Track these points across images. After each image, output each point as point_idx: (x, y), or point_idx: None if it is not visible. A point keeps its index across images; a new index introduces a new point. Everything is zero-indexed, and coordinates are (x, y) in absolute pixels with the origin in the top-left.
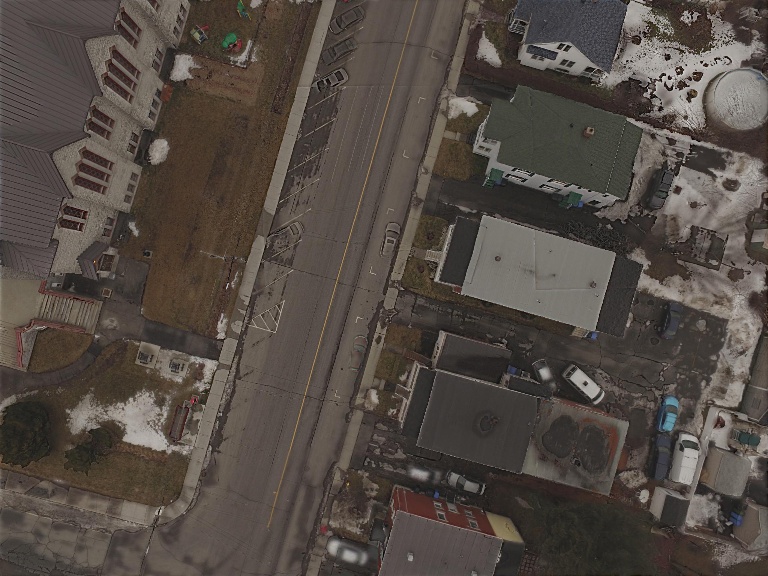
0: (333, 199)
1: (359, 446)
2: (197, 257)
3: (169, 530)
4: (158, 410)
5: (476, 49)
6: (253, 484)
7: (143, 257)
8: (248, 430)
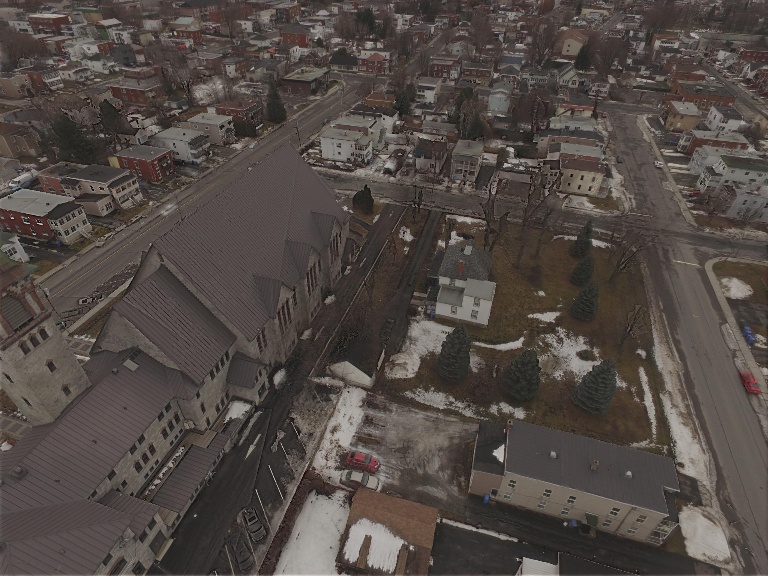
0: None
1: None
2: None
3: None
4: None
5: None
6: None
7: None
8: None
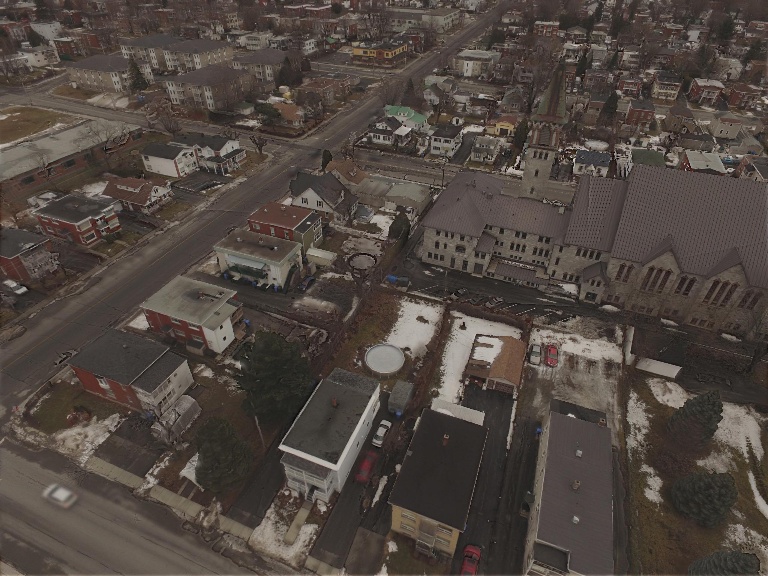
0: None
1: None
2: None
3: None
4: None
5: None
6: None
7: None
8: None
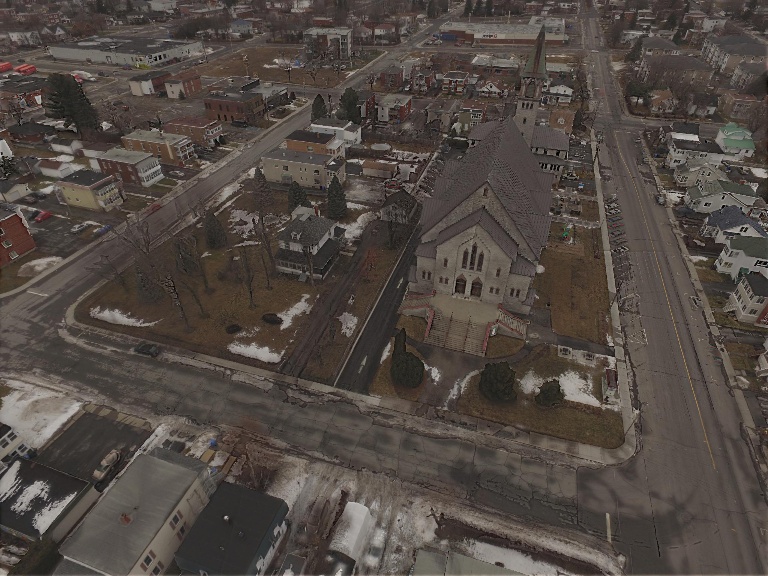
0: (648, 288)
1: (754, 411)
2: (579, 308)
3: (626, 468)
4: (584, 382)
5: (693, 238)
6: (683, 434)
7: (545, 307)
8: (658, 398)
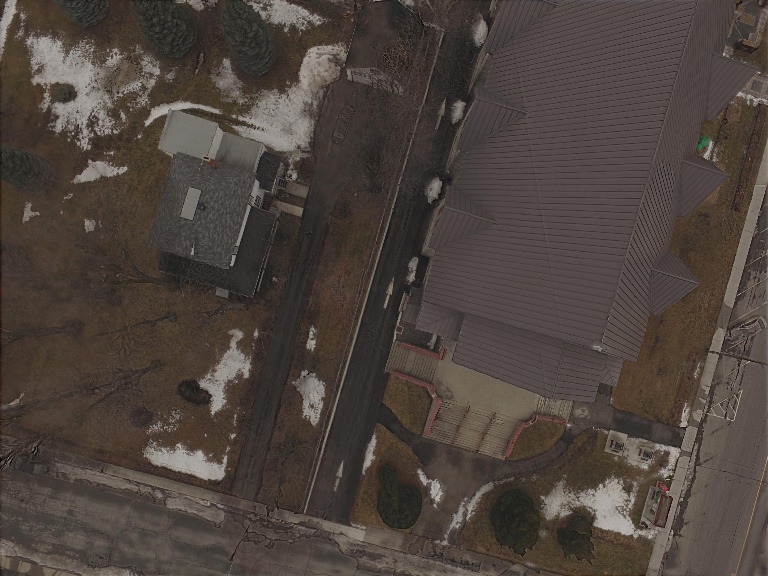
0: None
1: None
2: (663, 349)
3: None
4: (626, 496)
5: None
6: (713, 567)
7: None
8: (708, 515)
